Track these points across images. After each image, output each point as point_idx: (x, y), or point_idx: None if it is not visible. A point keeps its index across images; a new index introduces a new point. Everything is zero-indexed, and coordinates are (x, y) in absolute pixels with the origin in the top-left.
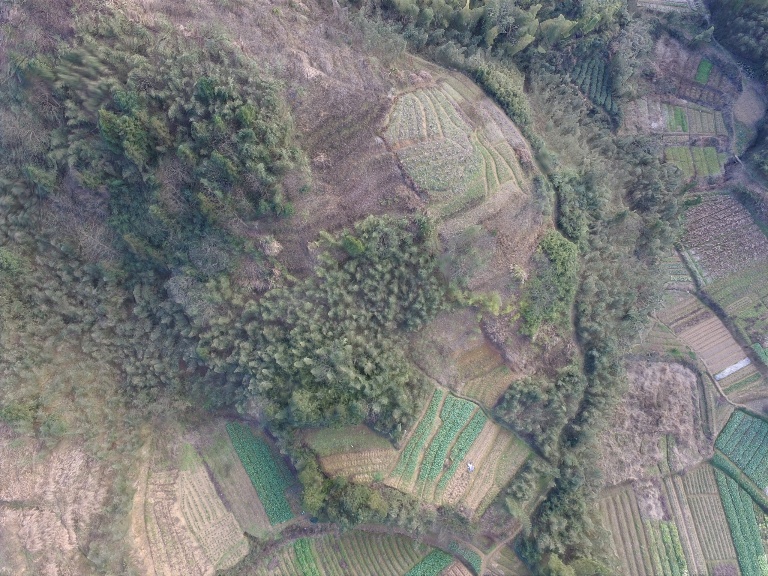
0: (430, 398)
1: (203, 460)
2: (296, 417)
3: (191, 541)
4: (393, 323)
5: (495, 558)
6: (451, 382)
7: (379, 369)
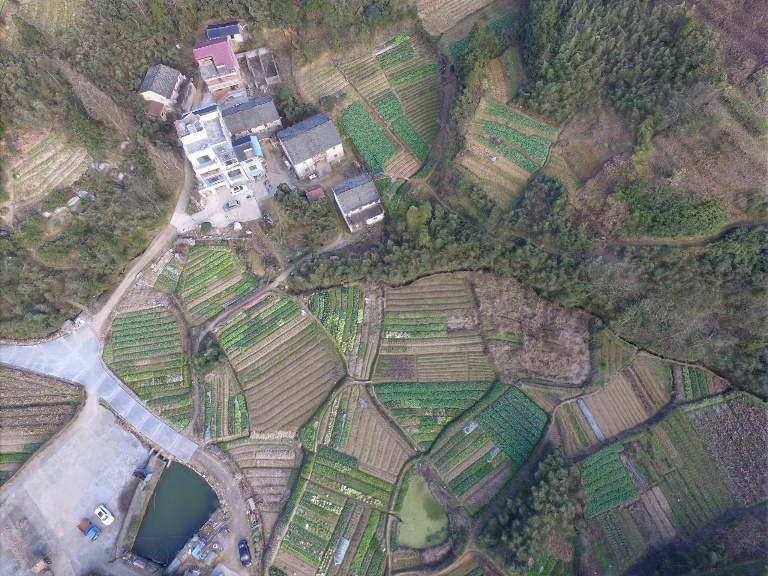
0: (548, 126)
1: (490, 4)
2: (537, 11)
3: (439, 4)
4: (615, 78)
5: (424, 187)
6: (562, 142)
7: (575, 68)
